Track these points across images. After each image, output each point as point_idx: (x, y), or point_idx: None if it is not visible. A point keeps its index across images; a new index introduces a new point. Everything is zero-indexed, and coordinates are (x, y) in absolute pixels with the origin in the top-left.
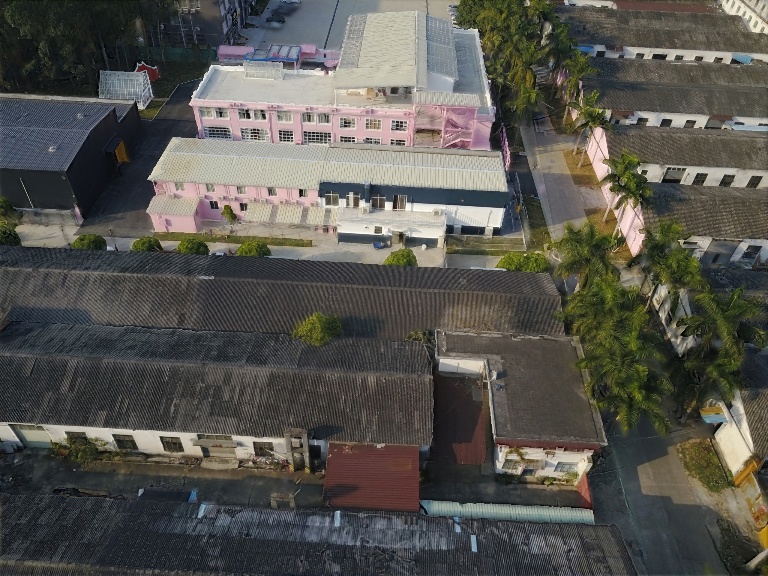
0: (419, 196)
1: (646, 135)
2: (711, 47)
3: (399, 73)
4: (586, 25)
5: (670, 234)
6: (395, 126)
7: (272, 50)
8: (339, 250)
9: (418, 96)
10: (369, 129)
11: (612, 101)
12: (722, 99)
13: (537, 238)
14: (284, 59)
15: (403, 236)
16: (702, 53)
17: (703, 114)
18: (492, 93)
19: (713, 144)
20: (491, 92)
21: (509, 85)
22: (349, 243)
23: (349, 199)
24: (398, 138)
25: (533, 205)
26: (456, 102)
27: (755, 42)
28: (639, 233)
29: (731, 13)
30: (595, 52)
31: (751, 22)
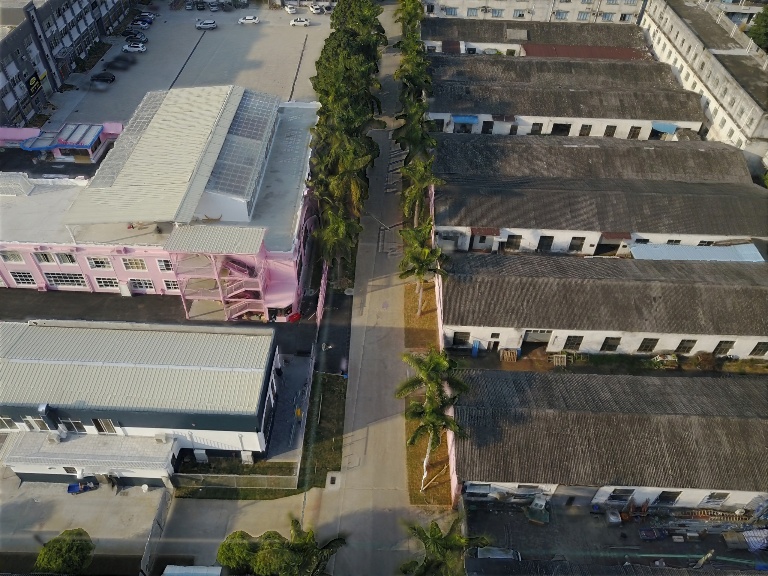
0: (128, 420)
1: (499, 281)
2: (625, 114)
3: (160, 197)
4: (470, 87)
5: (446, 552)
6: (164, 266)
7: (64, 132)
8: (17, 498)
9: (176, 236)
10: (131, 269)
11: (472, 214)
12: (619, 207)
13: (321, 460)
14: (73, 146)
15: (109, 477)
16: (614, 122)
17: (593, 230)
18: (309, 208)
19: (590, 293)
20: (307, 207)
21: (327, 200)
22: (37, 483)
23: (30, 422)
24: (174, 279)
25: (334, 392)
26: (225, 246)
27: (681, 106)
28: (454, 469)
29: (662, 58)
30: (480, 122)
31: (682, 73)
